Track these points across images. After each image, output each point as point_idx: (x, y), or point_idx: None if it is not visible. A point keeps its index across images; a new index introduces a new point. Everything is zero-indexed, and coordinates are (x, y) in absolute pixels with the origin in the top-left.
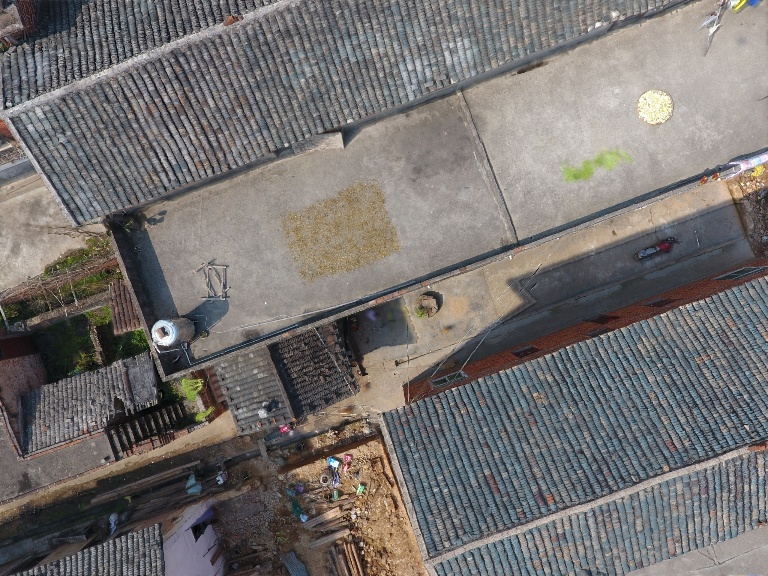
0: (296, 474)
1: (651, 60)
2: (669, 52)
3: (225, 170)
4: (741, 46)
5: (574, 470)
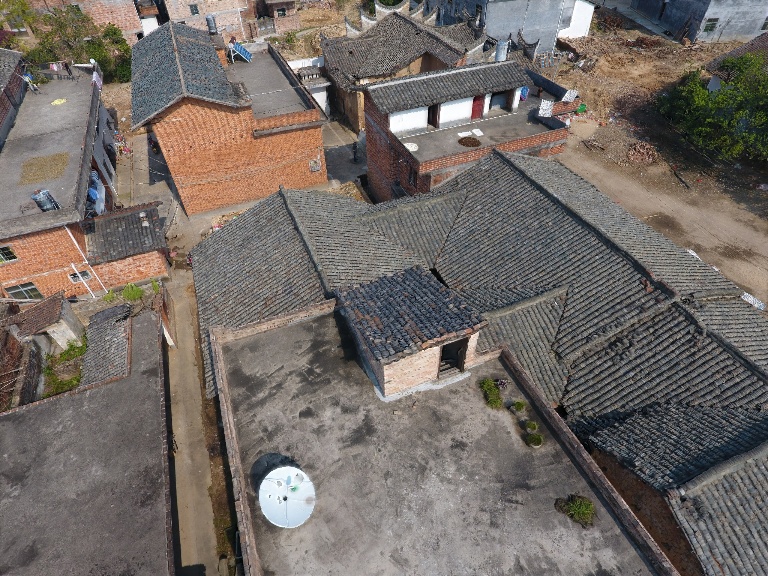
0: None
1: (38, 103)
2: (39, 100)
3: None
4: (51, 89)
5: None
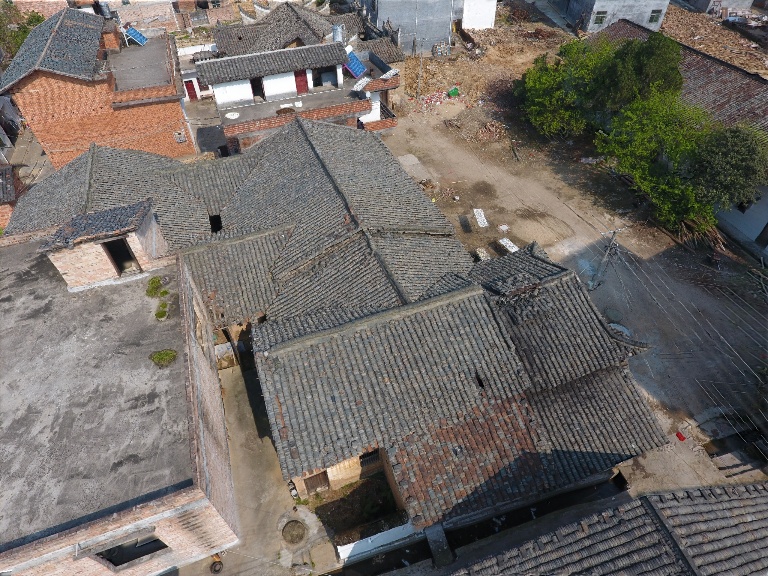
0: None
1: None
2: None
3: None
4: None
5: None
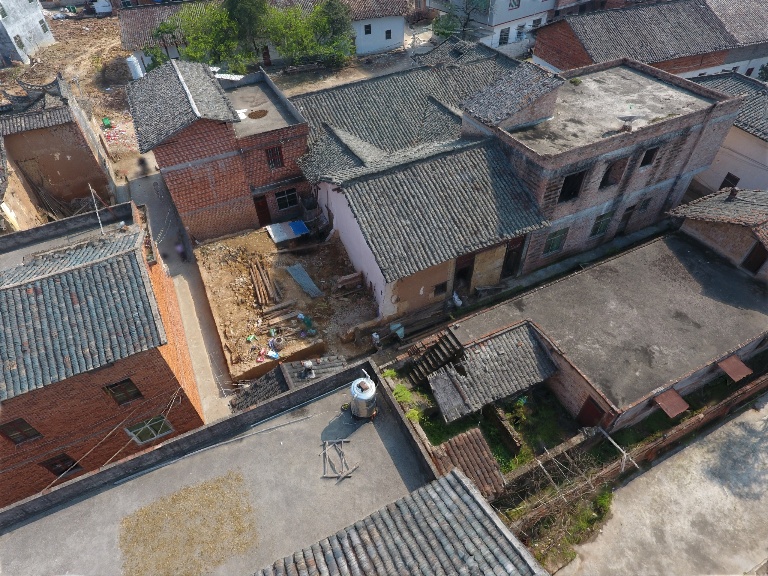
0: (307, 344)
1: None
2: None
3: (280, 561)
4: None
5: (2, 311)
